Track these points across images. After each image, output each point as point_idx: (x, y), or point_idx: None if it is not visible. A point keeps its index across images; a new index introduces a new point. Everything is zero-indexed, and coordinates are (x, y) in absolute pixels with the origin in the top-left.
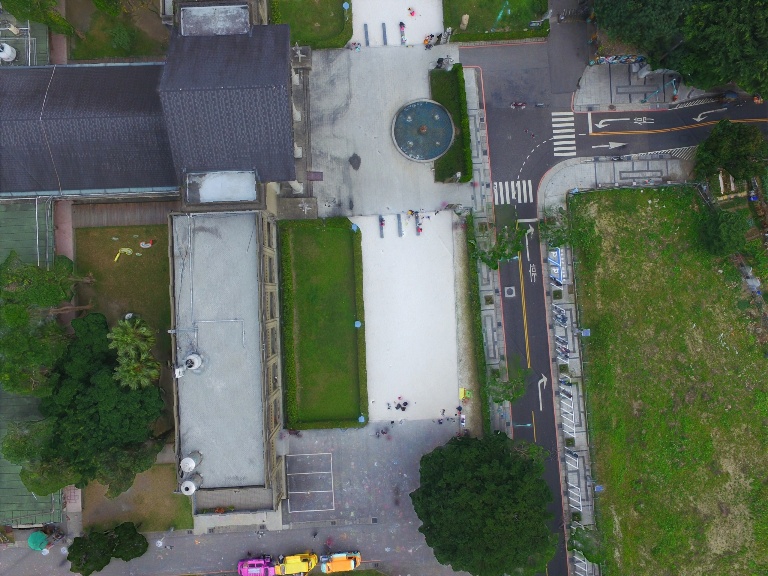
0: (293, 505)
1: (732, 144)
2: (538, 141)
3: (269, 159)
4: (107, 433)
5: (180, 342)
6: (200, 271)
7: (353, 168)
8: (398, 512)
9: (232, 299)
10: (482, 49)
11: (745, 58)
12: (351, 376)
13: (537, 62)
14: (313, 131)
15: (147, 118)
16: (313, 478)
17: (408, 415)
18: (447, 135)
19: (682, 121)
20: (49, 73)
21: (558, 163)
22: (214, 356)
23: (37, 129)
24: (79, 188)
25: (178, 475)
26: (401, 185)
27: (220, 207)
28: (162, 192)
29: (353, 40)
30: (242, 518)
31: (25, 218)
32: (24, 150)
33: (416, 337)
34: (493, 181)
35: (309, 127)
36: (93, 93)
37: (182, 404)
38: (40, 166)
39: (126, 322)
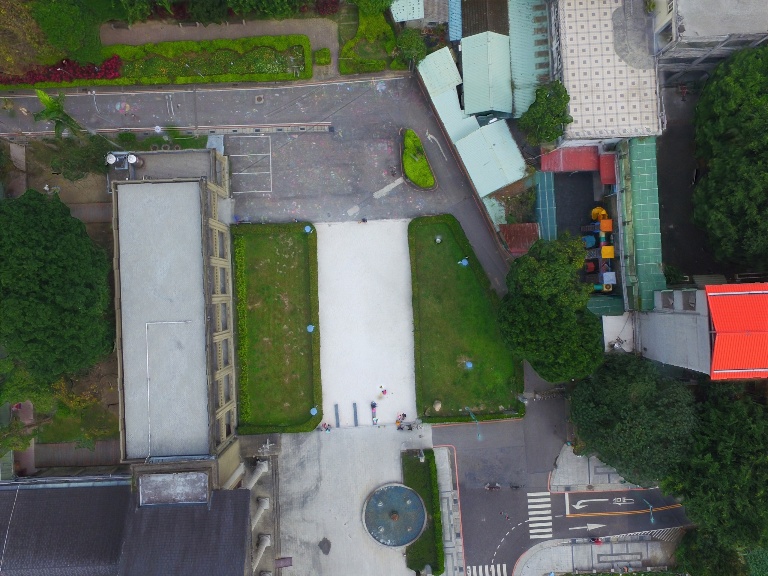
0: None
1: (712, 569)
2: (513, 523)
3: None
4: None
5: None
6: None
7: (323, 553)
8: None
9: None
10: (456, 427)
11: (723, 525)
12: None
13: (513, 440)
14: (282, 515)
15: (107, 566)
16: None
17: None
18: (419, 519)
19: (663, 501)
20: (12, 498)
21: (534, 545)
22: None
23: None
24: None
25: None
26: (372, 570)
27: None
28: None
29: (323, 421)
30: None
31: None
32: None
33: None
34: (466, 565)
35: (278, 512)
36: (54, 530)
37: None
38: None
39: None
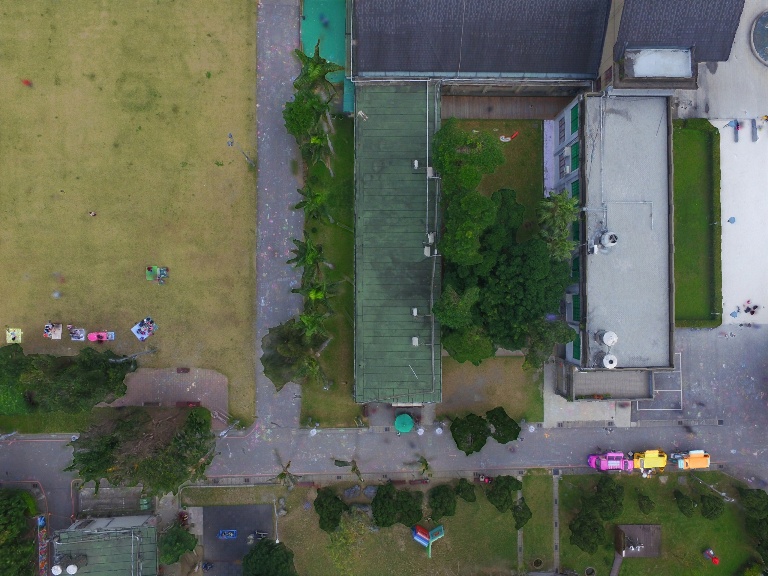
0: (642, 403)
1: None
2: None
3: (711, 36)
4: (534, 303)
5: (589, 222)
6: (610, 152)
7: (710, 72)
8: (744, 415)
9: (641, 181)
10: None
11: None
12: (702, 278)
13: None
14: None
15: None
16: (662, 377)
17: (757, 319)
18: None
19: None
20: None
21: None
22: (622, 237)
23: (458, 5)
24: (476, 70)
25: (589, 351)
26: (756, 91)
27: (652, 84)
28: (548, 80)
29: None
30: (591, 414)
31: (414, 100)
32: (438, 27)
33: (766, 242)
34: None
35: None
36: None
37: (589, 283)
38: (447, 45)
39: (567, 191)
